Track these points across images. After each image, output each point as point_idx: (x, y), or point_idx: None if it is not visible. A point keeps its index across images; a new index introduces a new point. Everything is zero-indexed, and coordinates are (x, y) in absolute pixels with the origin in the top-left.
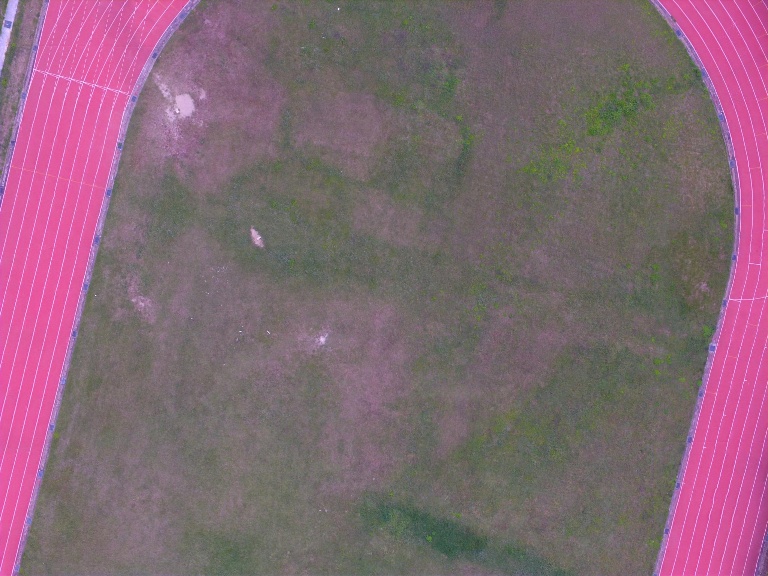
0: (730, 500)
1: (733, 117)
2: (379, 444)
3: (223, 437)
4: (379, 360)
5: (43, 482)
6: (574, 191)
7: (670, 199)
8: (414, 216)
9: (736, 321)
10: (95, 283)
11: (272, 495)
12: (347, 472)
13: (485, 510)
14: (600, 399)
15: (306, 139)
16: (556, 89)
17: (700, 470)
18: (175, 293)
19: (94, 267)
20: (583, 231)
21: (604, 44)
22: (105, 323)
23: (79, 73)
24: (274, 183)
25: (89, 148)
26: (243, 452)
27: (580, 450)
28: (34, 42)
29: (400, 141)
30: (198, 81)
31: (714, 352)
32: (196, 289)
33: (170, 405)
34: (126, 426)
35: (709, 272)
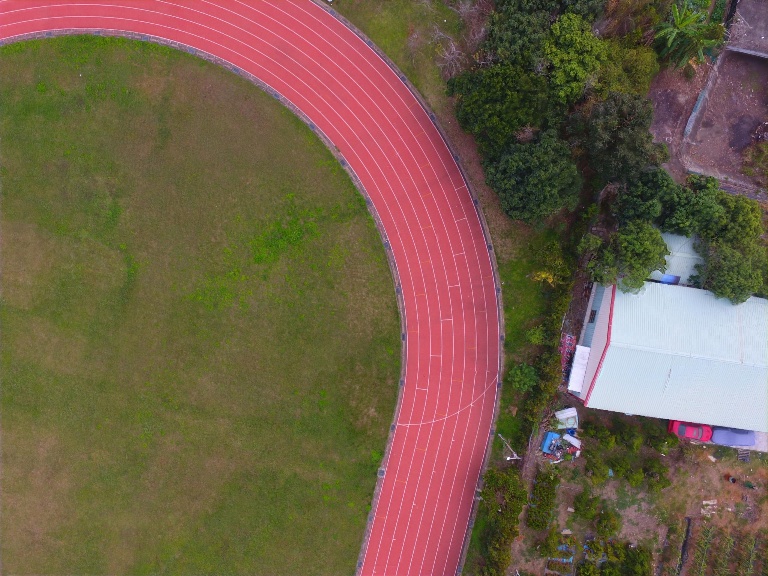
0: None
1: (398, 245)
2: (43, 574)
3: None
4: (43, 489)
5: None
6: (240, 318)
7: (336, 326)
8: (79, 344)
9: (404, 446)
10: None
11: None
12: None
13: None
14: (268, 525)
15: None
16: (221, 218)
17: None
18: None
19: None
20: (250, 358)
21: (268, 174)
22: None
23: None
24: None
25: None
26: None
27: None
28: None
29: (64, 269)
30: None
31: (383, 477)
32: None
33: None
34: None
35: (377, 397)
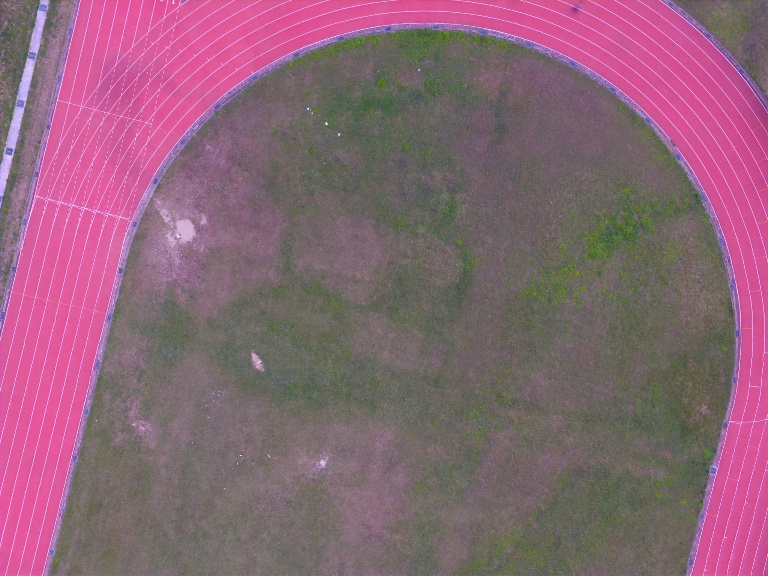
0: None
1: (733, 240)
2: (380, 567)
3: (223, 561)
4: (379, 483)
5: None
6: (574, 314)
7: (670, 322)
8: (414, 339)
9: (737, 443)
10: (96, 408)
11: None
12: None
13: None
14: (601, 522)
15: (307, 263)
16: (556, 213)
17: None
18: (176, 417)
19: (95, 392)
20: (583, 354)
21: (604, 168)
22: (105, 448)
23: (80, 199)
24: (275, 307)
25: (90, 273)
26: (243, 575)
27: (581, 573)
28: (35, 169)
29: (400, 265)
30: (199, 206)
31: (715, 474)
32: (197, 413)
33: (170, 529)
34: (126, 551)
35: (709, 395)
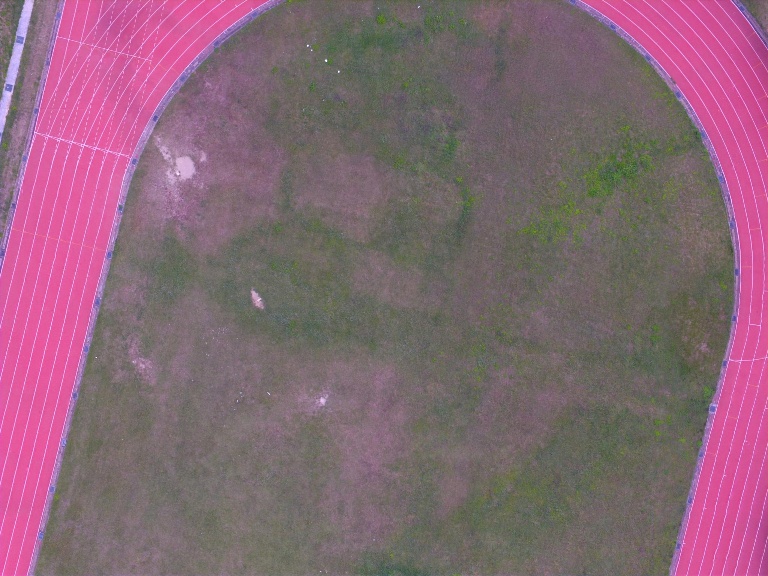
0: (730, 561)
1: (733, 178)
2: (379, 505)
3: (223, 498)
4: (379, 421)
5: (43, 544)
6: (574, 252)
7: (670, 260)
8: (414, 277)
9: (736, 382)
10: (96, 345)
11: (272, 556)
12: (347, 533)
13: (485, 571)
14: (600, 460)
15: (306, 201)
16: (556, 151)
17: (700, 531)
18: (175, 355)
19: (95, 329)
20: (583, 292)
21: (604, 106)
22: (105, 385)
23: (80, 136)
24: (274, 245)
25: (90, 210)
26: (243, 513)
27: (580, 511)
28: (35, 105)
29: (400, 203)
30: (198, 143)
31: (714, 413)
32: (196, 351)
33: (170, 467)
34: (126, 488)
35: (709, 333)
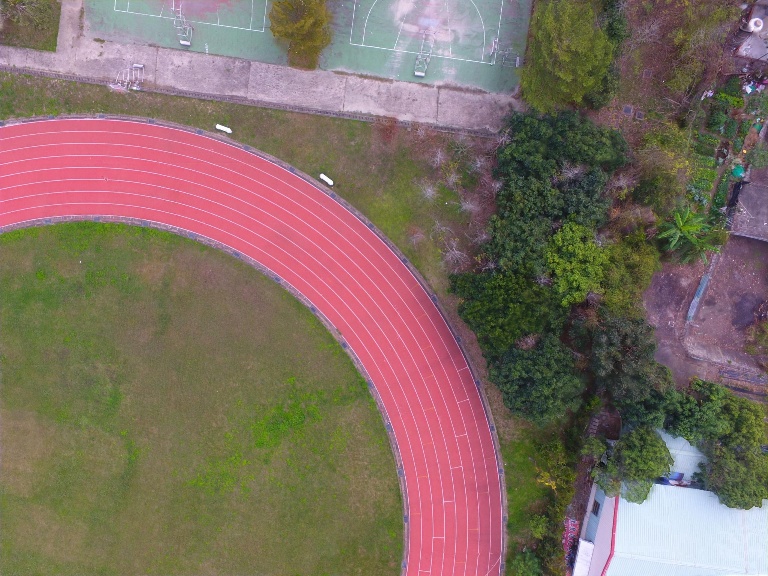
0: None
1: (400, 427)
2: None
3: None
4: None
5: None
6: (242, 503)
7: (338, 509)
8: (80, 531)
9: None
10: None
11: None
12: None
13: None
14: None
15: None
16: (222, 403)
17: None
18: None
19: None
20: (252, 543)
21: (269, 358)
22: None
23: None
24: None
25: None
26: None
27: None
28: None
29: (64, 457)
30: None
31: None
32: None
33: None
34: None
35: None
